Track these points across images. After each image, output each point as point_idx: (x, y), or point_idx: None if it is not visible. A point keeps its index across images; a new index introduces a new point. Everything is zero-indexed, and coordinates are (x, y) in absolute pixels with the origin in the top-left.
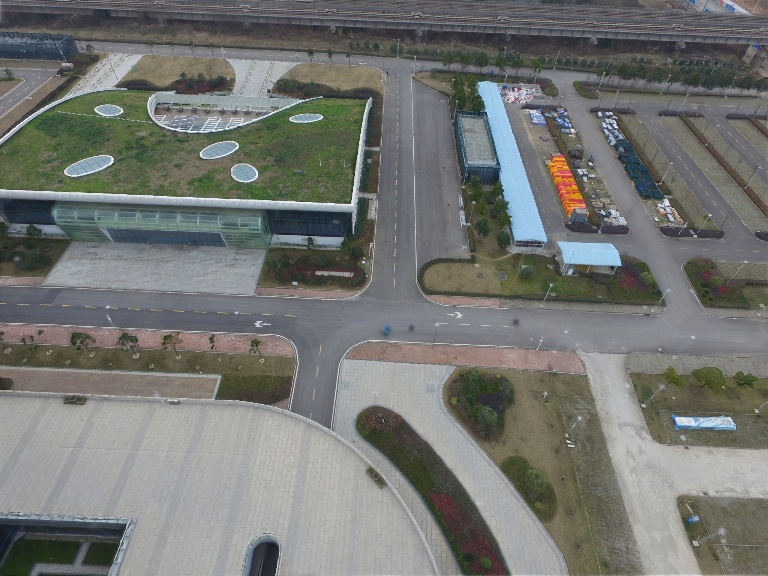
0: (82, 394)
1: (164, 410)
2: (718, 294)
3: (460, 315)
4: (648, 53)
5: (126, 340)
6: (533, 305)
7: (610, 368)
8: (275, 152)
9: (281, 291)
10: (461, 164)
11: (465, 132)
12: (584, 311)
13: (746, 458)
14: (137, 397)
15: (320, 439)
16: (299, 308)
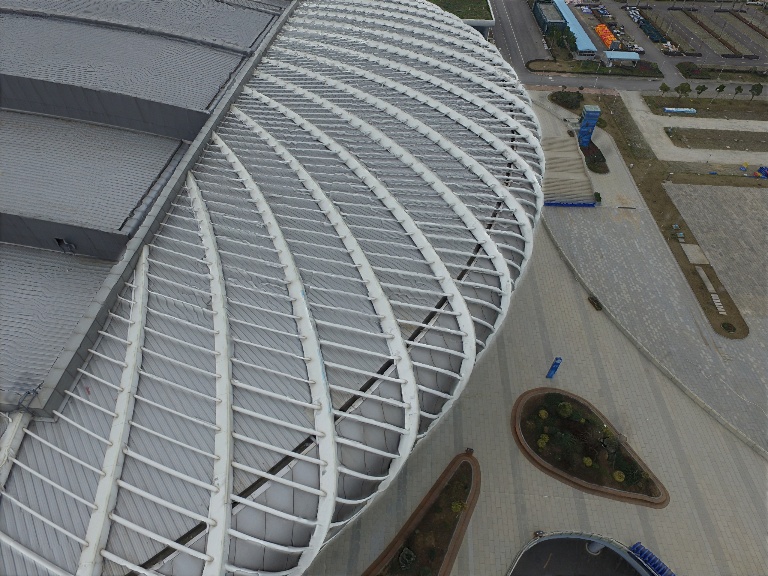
0: None
1: None
2: (694, 73)
3: (551, 78)
4: None
5: None
6: (590, 76)
7: (633, 95)
8: (441, 5)
9: None
10: (542, 25)
11: (543, 10)
12: (619, 78)
13: (700, 120)
14: None
15: None
16: None
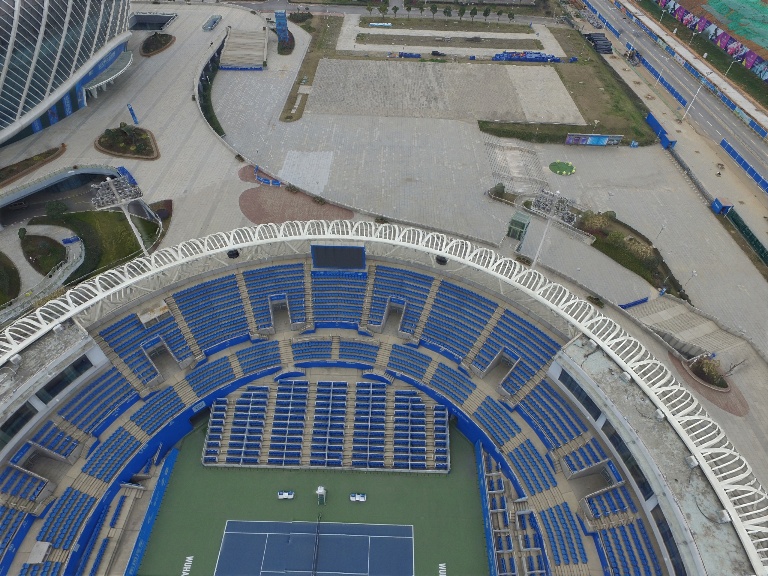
0: (159, 1)
1: (186, 5)
2: None
3: None
4: None
5: None
6: None
7: (354, 16)
8: None
9: (231, 1)
10: None
11: None
12: (353, 7)
13: None
14: (177, 2)
15: (237, 9)
16: (237, 4)
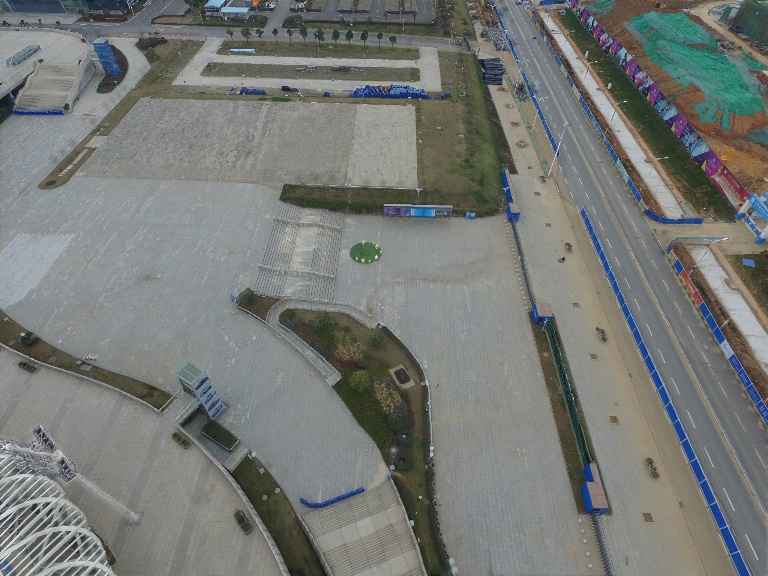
0: None
1: None
2: None
3: (163, 29)
4: None
5: (5, 23)
6: (200, 27)
7: (217, 40)
8: None
9: (85, 23)
10: None
11: None
12: None
13: (250, 57)
14: (3, 27)
15: None
16: None
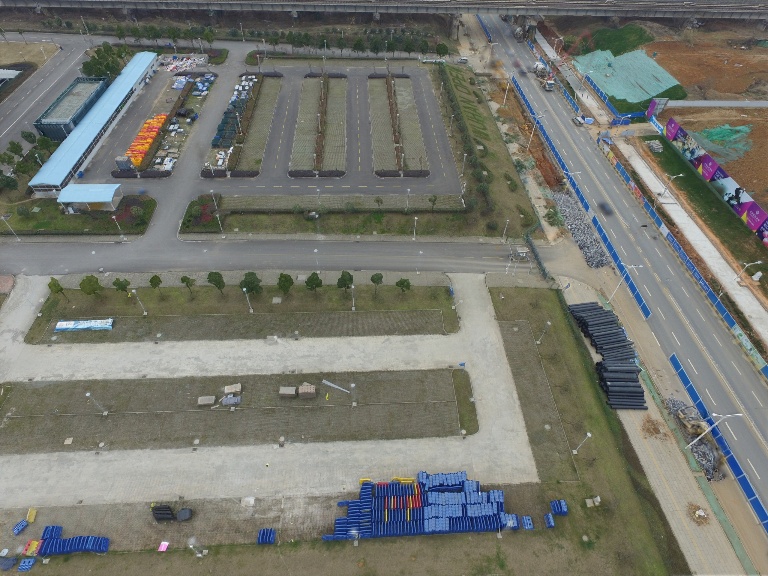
0: None
1: None
2: (198, 222)
3: None
4: (349, 24)
5: None
6: (12, 240)
7: (38, 287)
8: None
9: None
10: None
11: (69, 95)
12: (58, 242)
13: (98, 350)
14: None
15: None
16: None
